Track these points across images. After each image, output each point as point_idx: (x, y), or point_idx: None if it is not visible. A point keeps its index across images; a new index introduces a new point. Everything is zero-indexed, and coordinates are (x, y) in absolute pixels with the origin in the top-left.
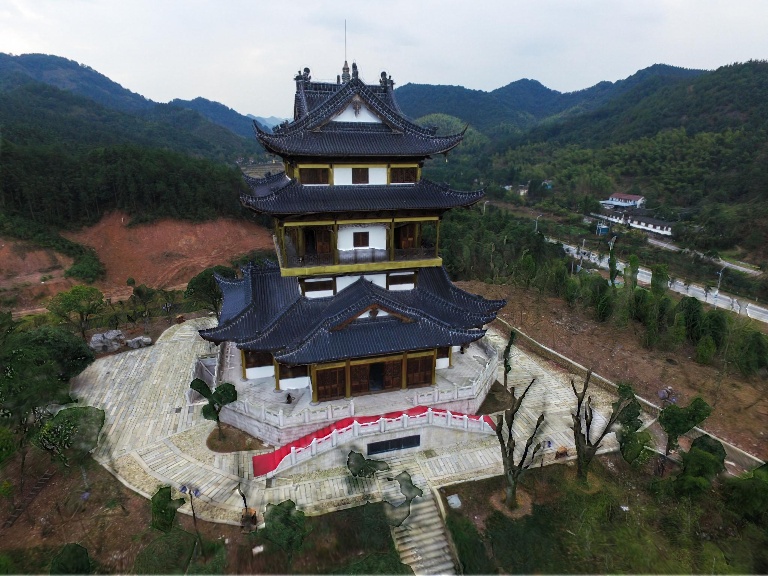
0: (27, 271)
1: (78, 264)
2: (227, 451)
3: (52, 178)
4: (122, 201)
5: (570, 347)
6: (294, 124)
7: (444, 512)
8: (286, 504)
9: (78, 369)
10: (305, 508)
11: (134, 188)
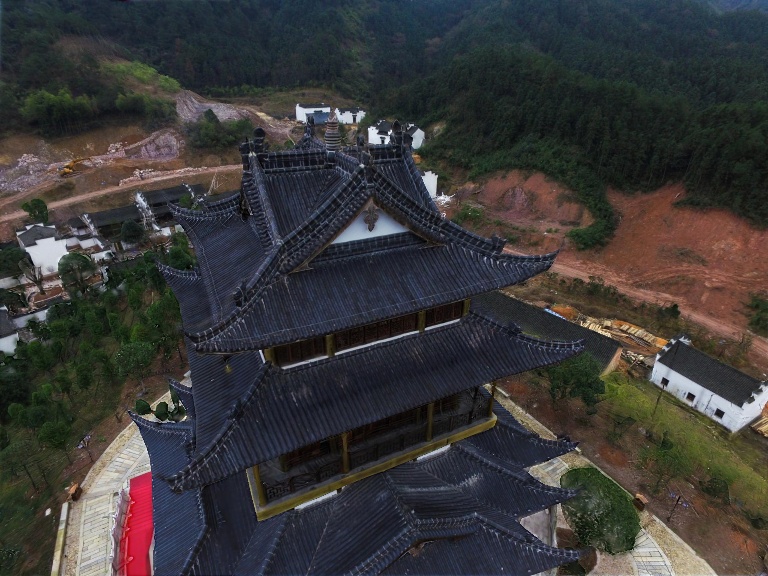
0: (553, 218)
1: (591, 227)
2: None
3: (642, 135)
4: (690, 174)
5: None
6: (217, 203)
7: None
8: None
9: None
10: (78, 532)
11: (708, 162)
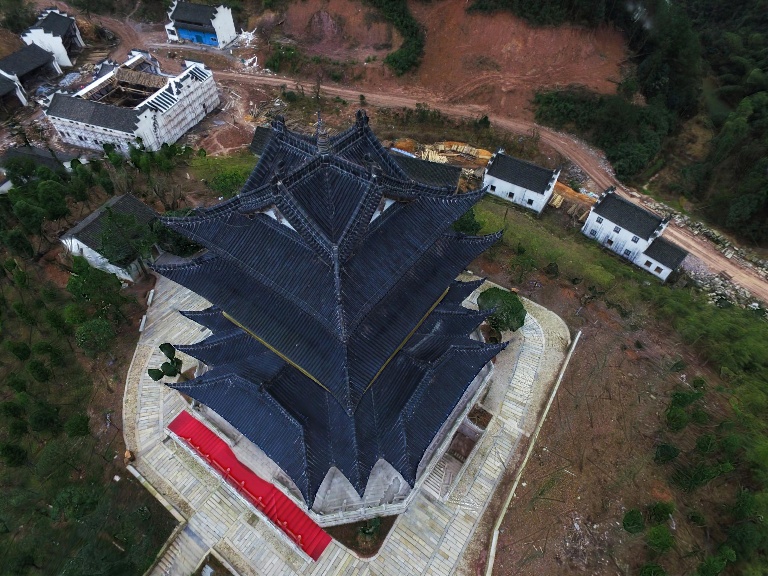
0: (366, 43)
1: (403, 48)
2: (180, 392)
3: None
4: None
5: (518, 567)
6: (214, 208)
7: (195, 570)
8: (74, 497)
9: (188, 254)
10: (158, 477)
11: None
